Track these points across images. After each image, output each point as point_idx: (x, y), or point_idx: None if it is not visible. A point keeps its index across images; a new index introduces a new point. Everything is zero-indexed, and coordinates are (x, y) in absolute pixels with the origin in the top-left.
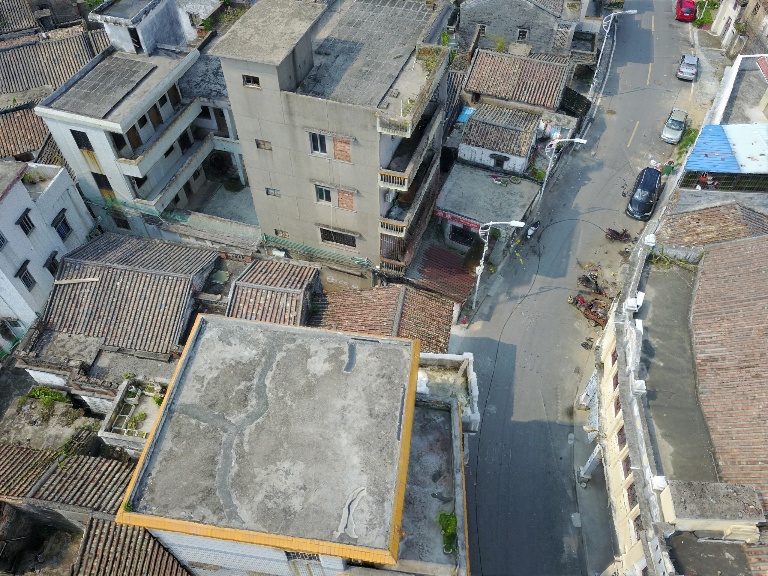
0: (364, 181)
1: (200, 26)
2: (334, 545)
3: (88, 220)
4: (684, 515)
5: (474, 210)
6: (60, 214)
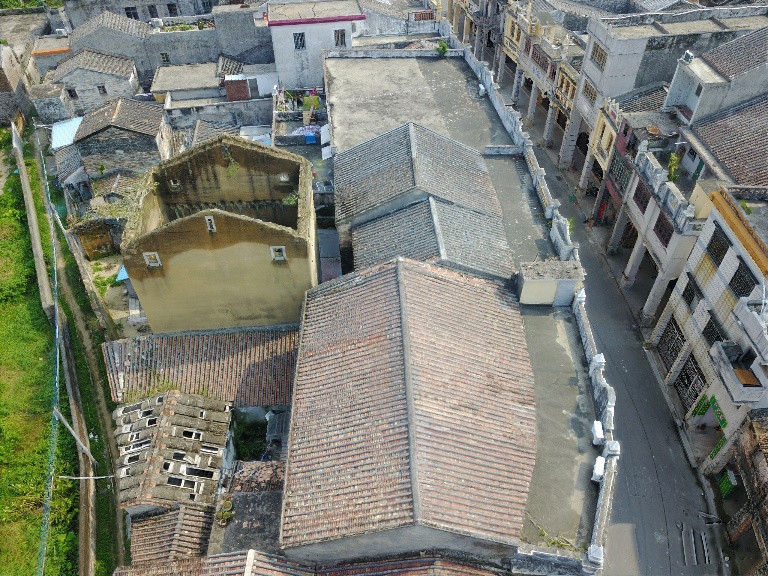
0: None
1: None
2: None
3: None
4: (575, 262)
5: None
6: None
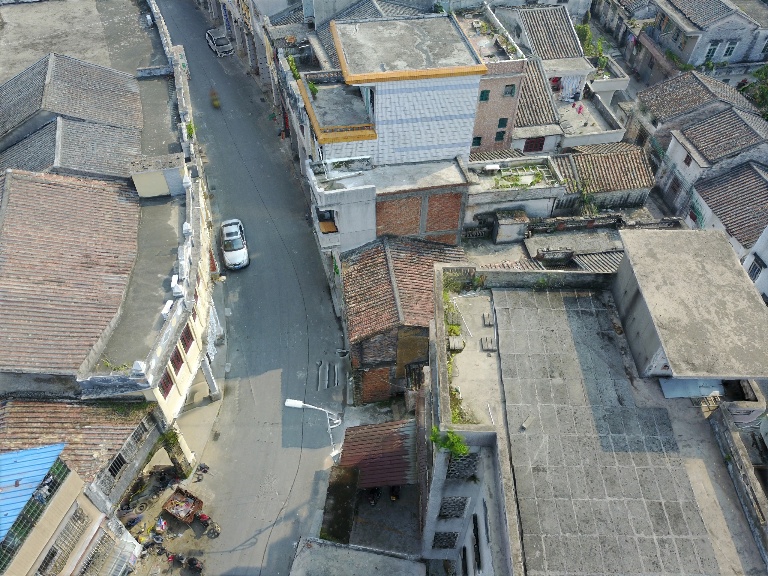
0: None
1: None
2: None
3: None
4: (179, 154)
5: (363, 571)
6: None
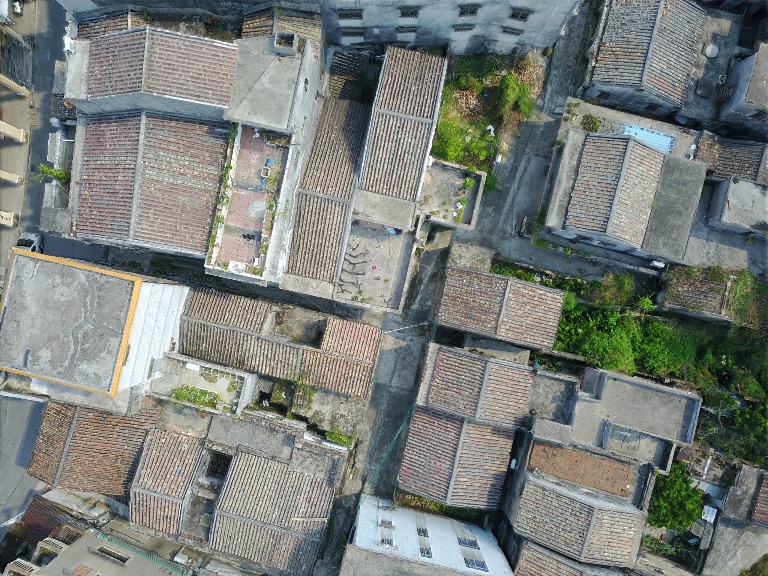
0: (52, 575)
1: None
2: (39, 258)
3: None
4: None
5: None
6: None
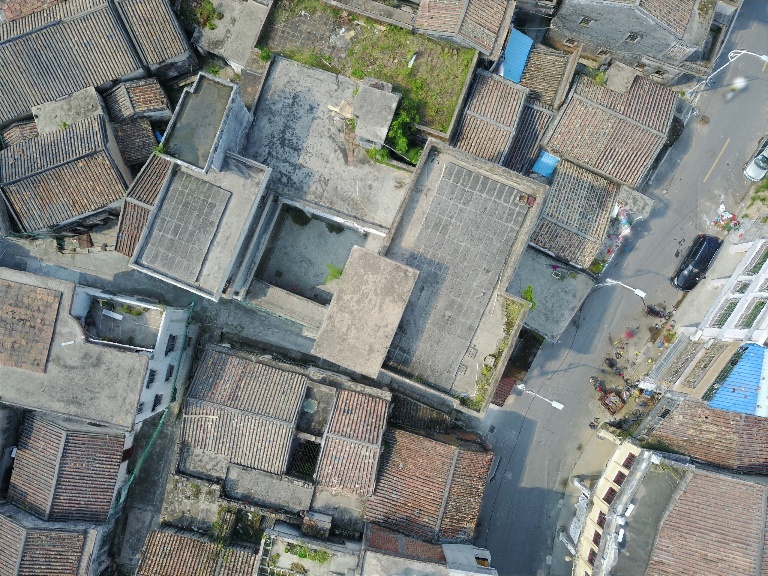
0: None
1: (255, 48)
2: None
3: (185, 315)
4: None
5: None
6: (169, 342)
